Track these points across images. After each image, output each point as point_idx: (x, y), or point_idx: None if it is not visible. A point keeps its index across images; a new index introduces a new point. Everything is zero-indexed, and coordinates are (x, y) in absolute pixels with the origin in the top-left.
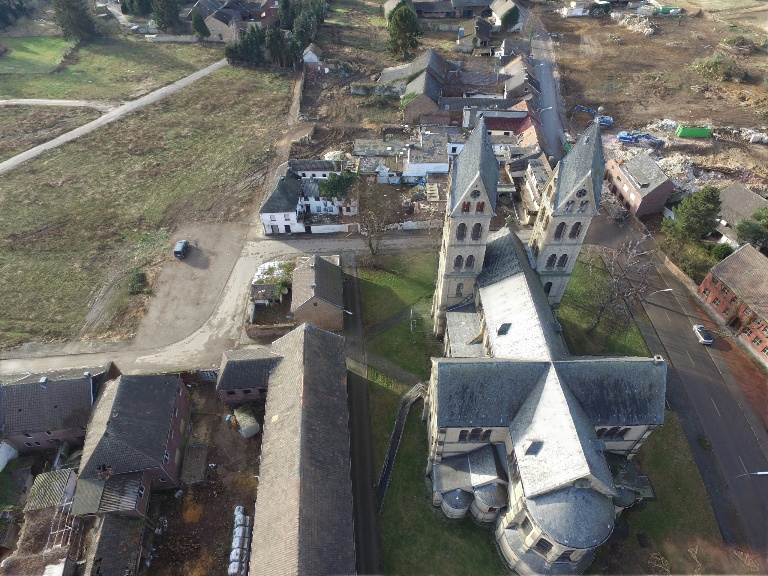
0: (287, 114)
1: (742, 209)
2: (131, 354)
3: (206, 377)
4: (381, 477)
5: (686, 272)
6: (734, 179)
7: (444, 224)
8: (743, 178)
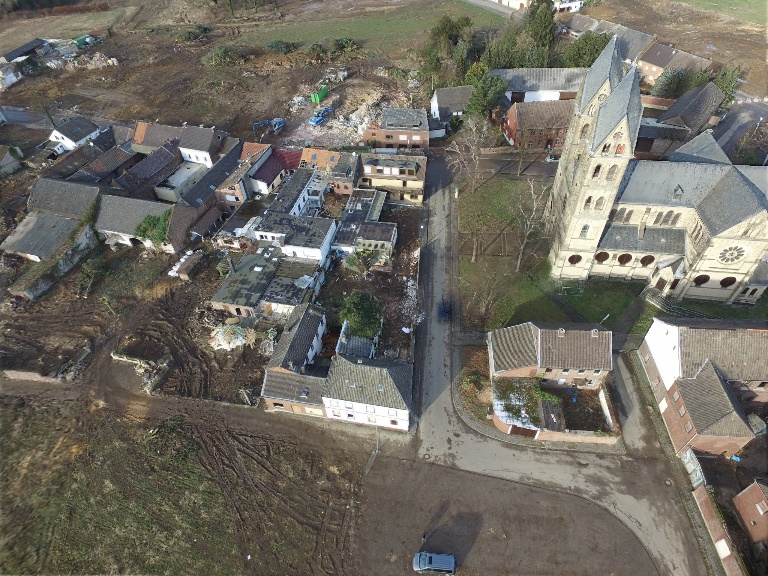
0: (28, 400)
1: (458, 100)
2: None
3: (697, 484)
4: None
5: (499, 146)
6: (391, 100)
7: (585, 186)
8: (391, 96)
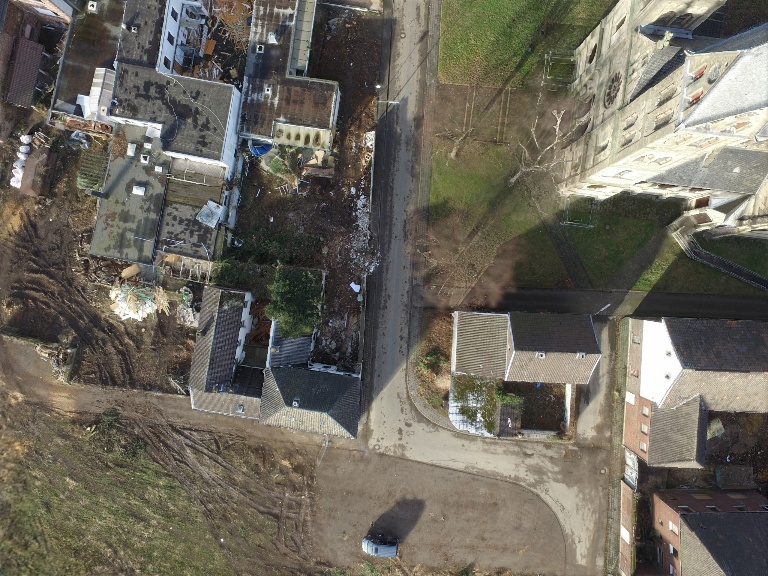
0: None
1: None
2: (572, 573)
3: (628, 479)
4: (767, 291)
5: None
6: None
7: (647, 148)
8: None
